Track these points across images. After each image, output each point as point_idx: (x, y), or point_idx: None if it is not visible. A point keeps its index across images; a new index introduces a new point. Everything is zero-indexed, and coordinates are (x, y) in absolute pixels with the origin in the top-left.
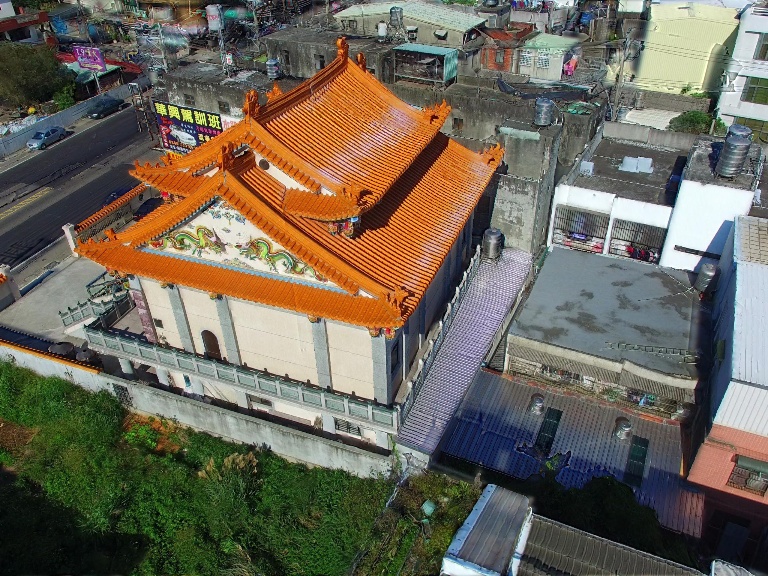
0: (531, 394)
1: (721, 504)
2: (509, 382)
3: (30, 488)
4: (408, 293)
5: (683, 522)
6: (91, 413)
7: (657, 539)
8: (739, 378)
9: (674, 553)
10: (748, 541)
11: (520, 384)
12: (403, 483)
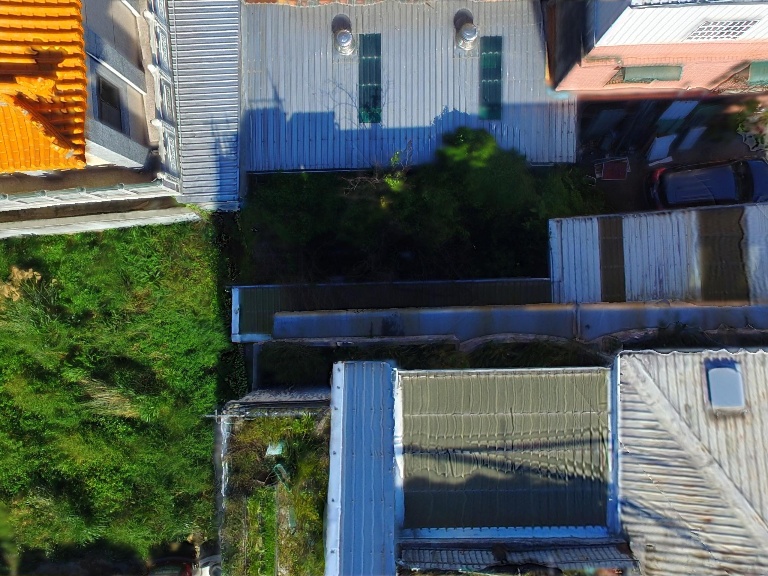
0: (329, 21)
1: (595, 99)
2: (292, 11)
3: None
4: (52, 59)
5: (555, 148)
6: None
7: (529, 193)
8: (642, 1)
9: (548, 194)
10: (623, 121)
11: (309, 8)
12: (228, 441)
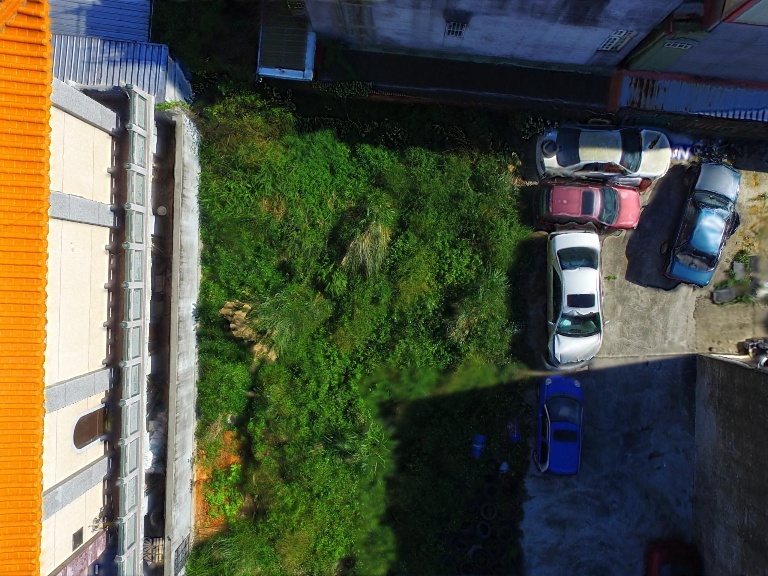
0: None
1: None
2: None
3: (347, 574)
4: None
5: None
6: (229, 575)
7: None
8: None
9: None
10: None
11: None
12: None
